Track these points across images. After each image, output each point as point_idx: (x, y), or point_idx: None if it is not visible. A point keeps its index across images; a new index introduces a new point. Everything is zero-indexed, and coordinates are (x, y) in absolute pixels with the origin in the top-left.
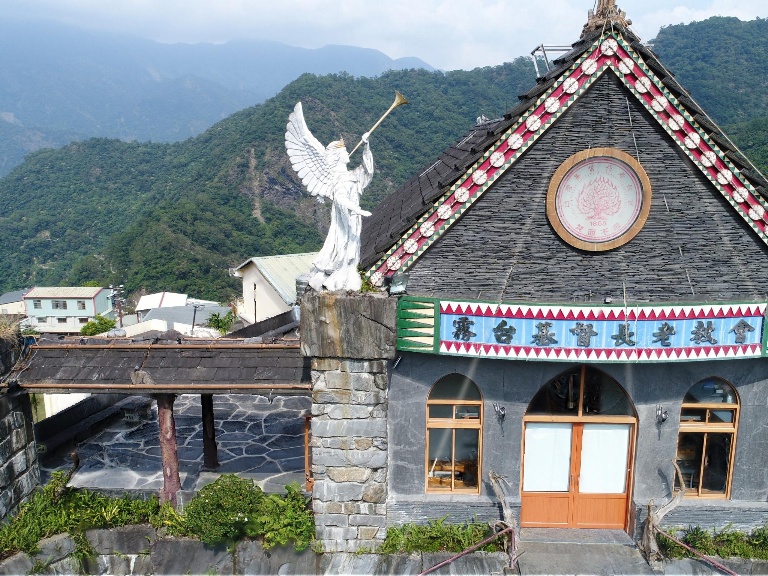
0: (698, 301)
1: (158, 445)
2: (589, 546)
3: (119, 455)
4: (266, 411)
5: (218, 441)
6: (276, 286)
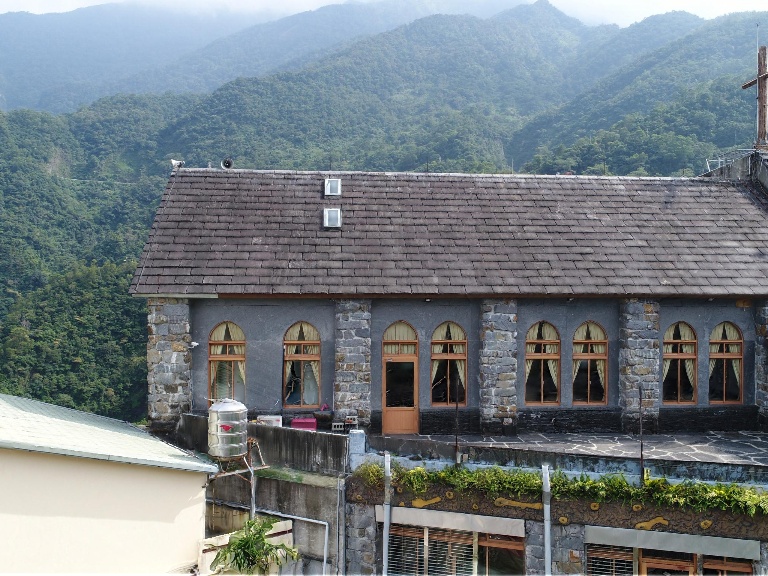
0: None
1: None
2: None
3: None
4: (715, 456)
5: None
6: (136, 457)
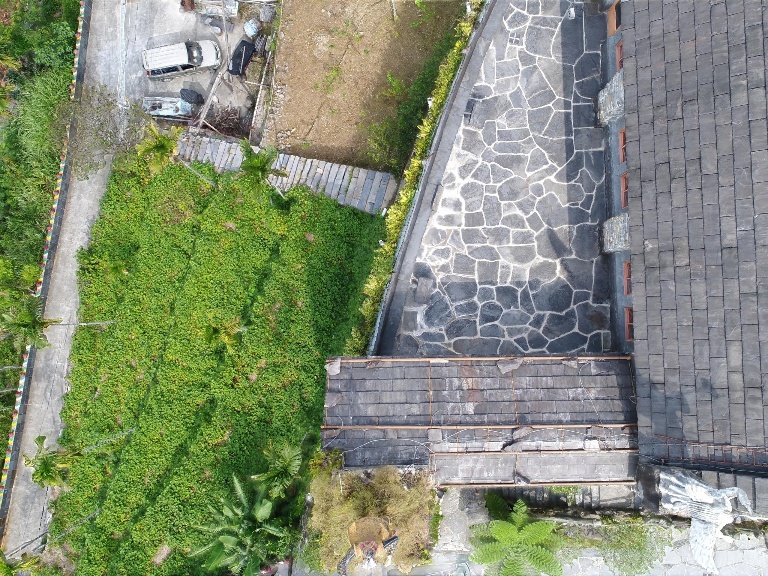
0: None
1: (459, 337)
2: None
3: None
4: (526, 264)
5: (503, 327)
6: None
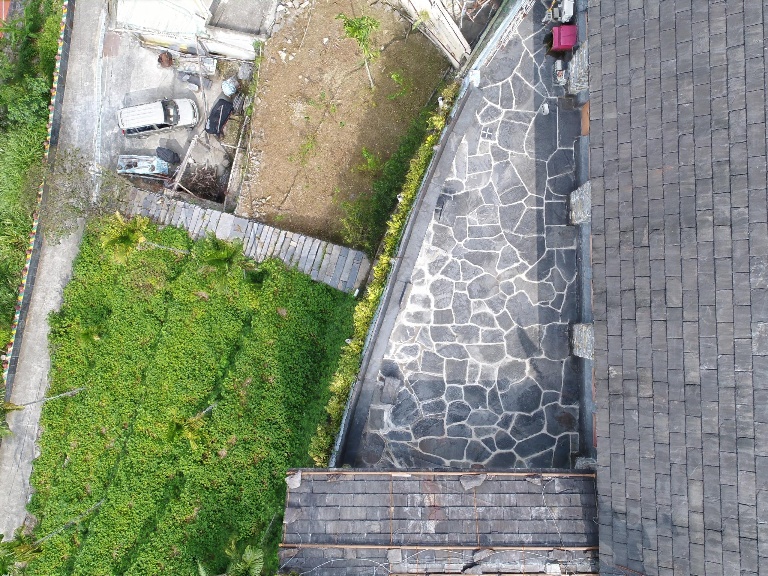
0: None
1: (425, 436)
2: None
3: (402, 455)
4: (495, 363)
5: (470, 427)
6: None
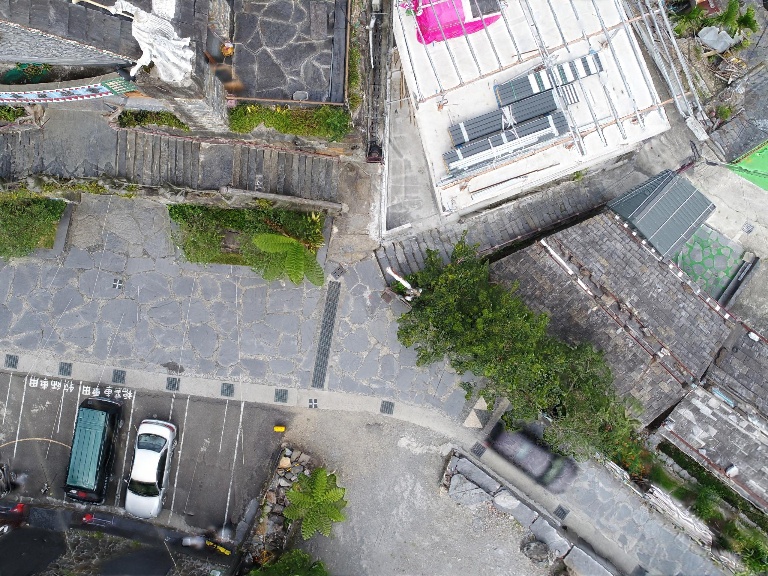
0: (54, 85)
1: None
2: (88, 113)
3: None
4: None
5: None
6: None
